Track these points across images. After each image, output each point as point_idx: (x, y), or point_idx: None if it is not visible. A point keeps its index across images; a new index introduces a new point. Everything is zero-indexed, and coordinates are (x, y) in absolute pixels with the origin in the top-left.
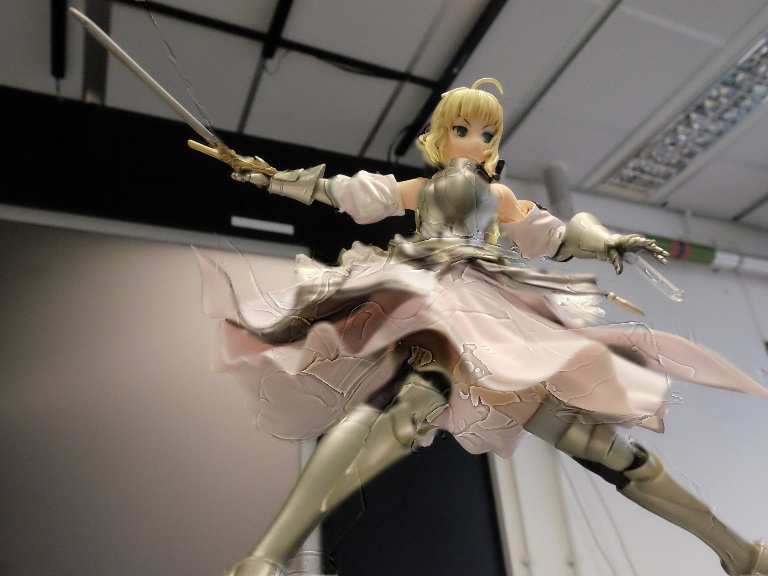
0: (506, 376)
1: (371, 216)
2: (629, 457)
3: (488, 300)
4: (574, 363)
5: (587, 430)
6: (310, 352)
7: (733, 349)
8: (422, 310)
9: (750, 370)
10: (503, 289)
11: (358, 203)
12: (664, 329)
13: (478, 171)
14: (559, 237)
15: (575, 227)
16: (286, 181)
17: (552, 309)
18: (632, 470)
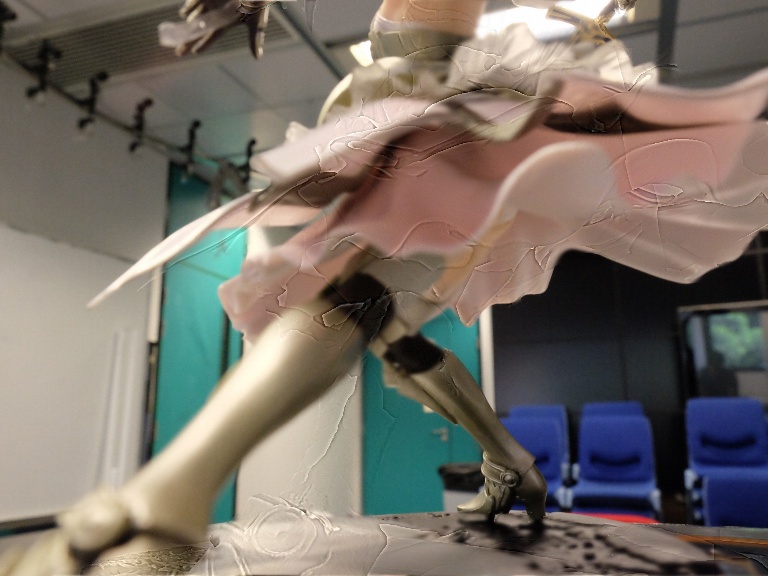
0: None
1: (564, 1)
2: None
3: None
4: None
5: None
6: None
7: None
8: None
9: None
10: None
11: None
12: None
13: None
14: None
15: None
16: None
17: None
18: None
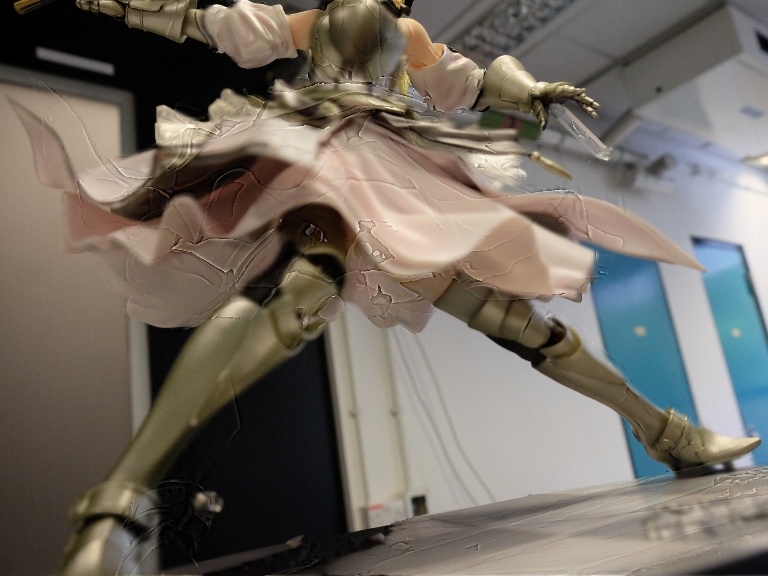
0: (412, 257)
1: (256, 58)
2: (546, 333)
3: (389, 165)
4: (492, 241)
5: (503, 307)
6: (170, 232)
7: (664, 215)
8: (308, 178)
9: (679, 238)
10: (412, 148)
11: (238, 41)
12: (592, 194)
13: (383, 0)
14: (477, 85)
15: (496, 73)
16: (146, 11)
17: (468, 172)
18: (548, 347)
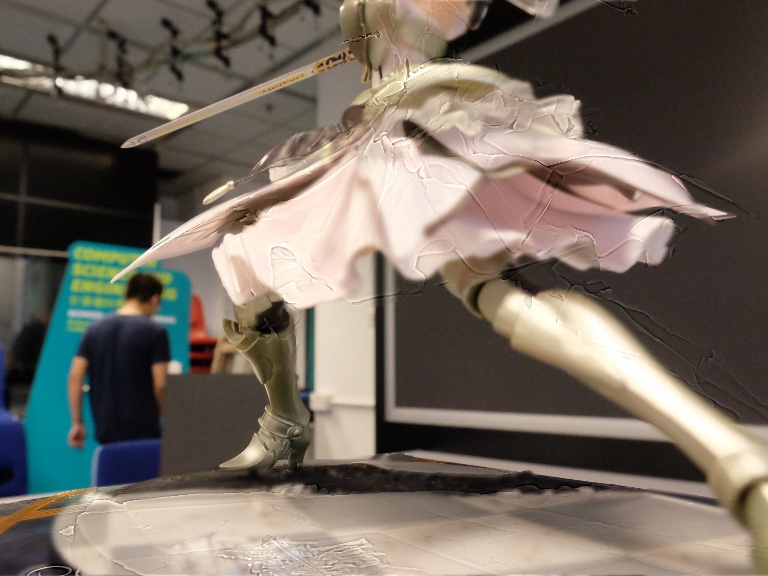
0: None
1: None
2: None
3: None
4: None
5: None
6: None
7: None
8: None
9: None
10: None
11: None
12: (434, 176)
13: None
14: None
15: None
16: None
17: None
18: None
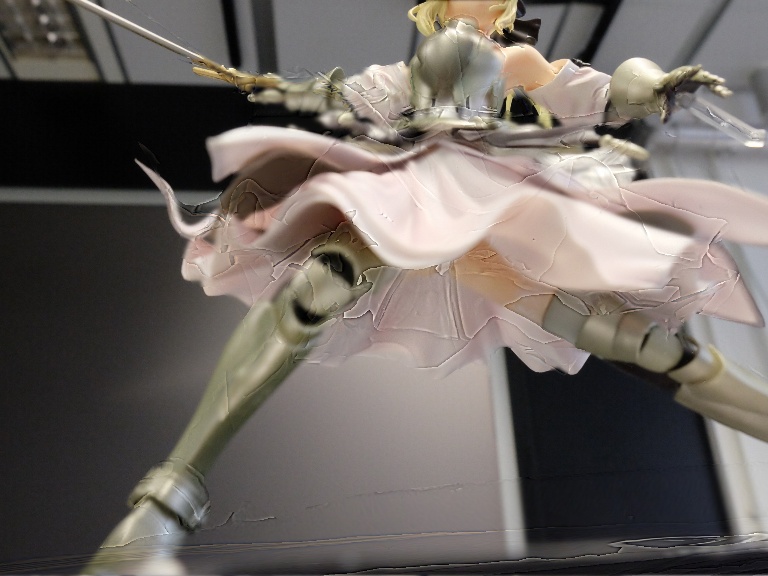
0: (417, 249)
1: None
2: (675, 354)
3: (362, 152)
4: (487, 219)
5: (612, 323)
6: None
7: None
8: None
9: None
10: (489, 160)
11: None
12: (690, 175)
13: (467, 27)
14: (605, 96)
15: (624, 79)
16: None
17: None
18: (677, 370)
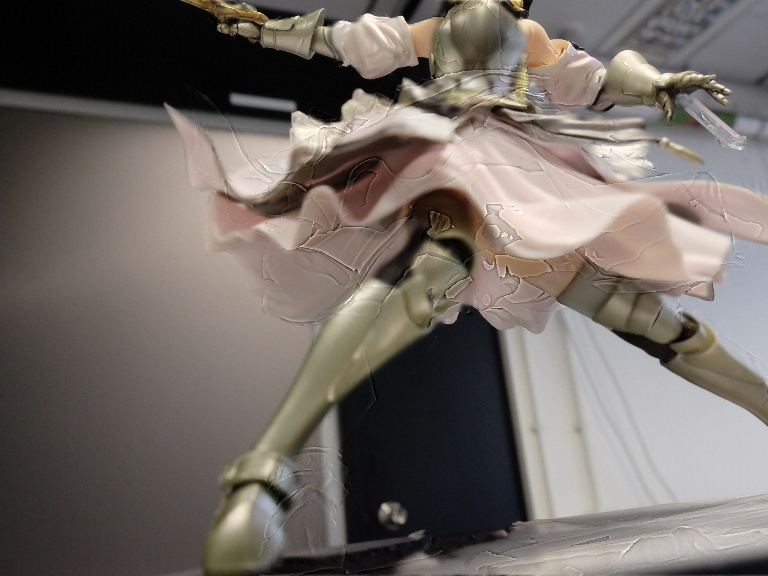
0: (539, 241)
1: (379, 67)
2: (676, 328)
3: (516, 149)
4: (621, 222)
5: (629, 300)
6: (308, 223)
7: None
8: (437, 166)
9: None
10: (533, 142)
11: (363, 52)
12: (725, 180)
13: (502, 1)
14: (598, 81)
15: (617, 68)
16: (279, 30)
17: (592, 163)
18: (680, 342)
